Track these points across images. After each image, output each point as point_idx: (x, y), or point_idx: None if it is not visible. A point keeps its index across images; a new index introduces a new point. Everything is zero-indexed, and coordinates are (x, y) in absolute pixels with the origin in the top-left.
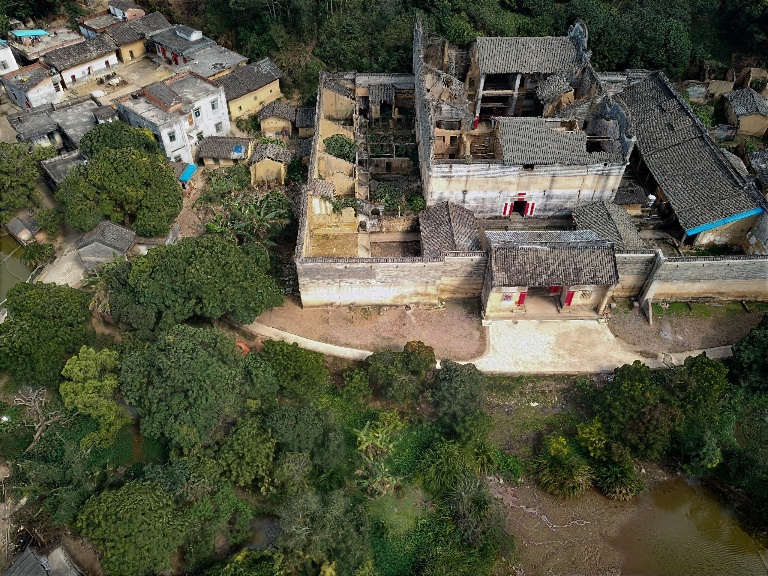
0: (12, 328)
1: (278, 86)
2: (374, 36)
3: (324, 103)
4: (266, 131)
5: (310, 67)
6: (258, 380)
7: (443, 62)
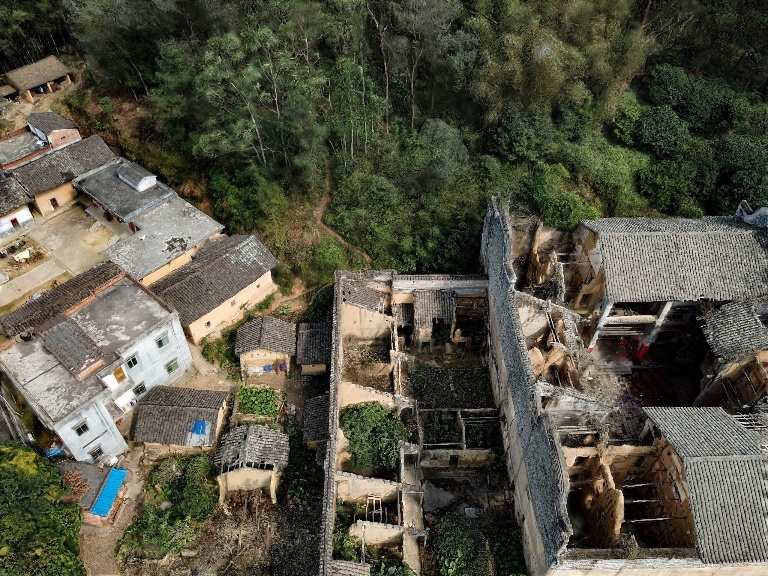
0: None
1: (269, 276)
2: (419, 200)
3: (342, 320)
4: (249, 364)
5: (319, 252)
6: None
7: (531, 251)
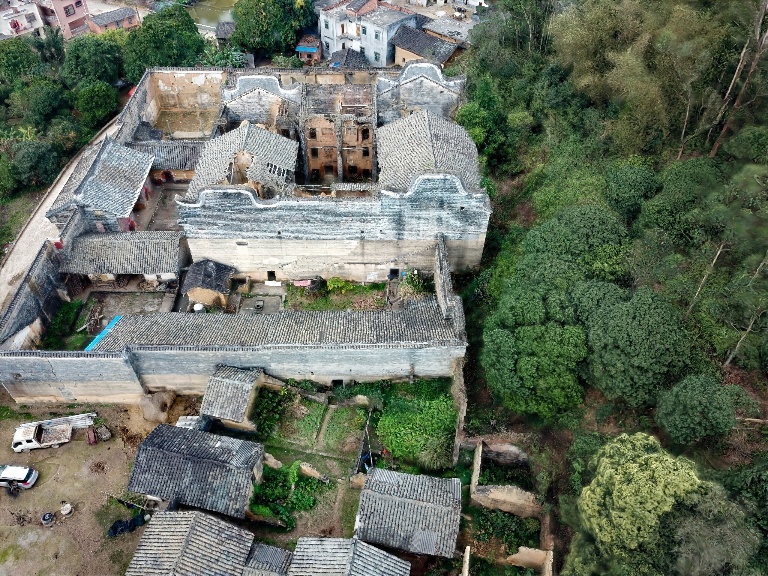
0: None
1: None
2: None
3: None
4: None
5: None
6: (80, 84)
7: None
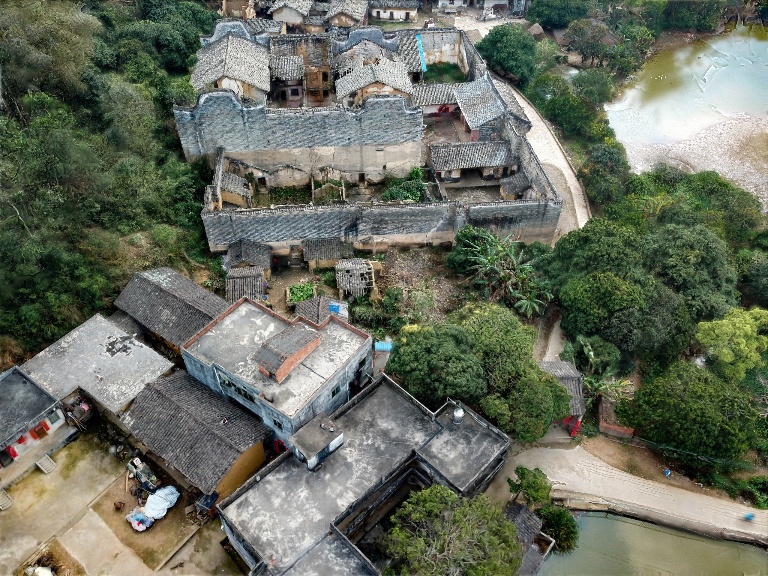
0: None
1: None
2: None
3: None
4: None
5: (165, 236)
6: None
7: None
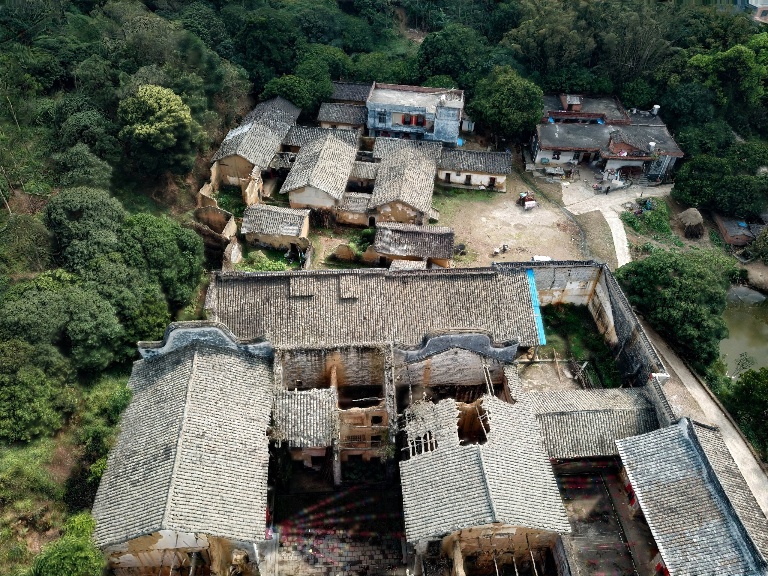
0: None
1: None
2: None
3: None
4: None
5: None
6: None
7: None
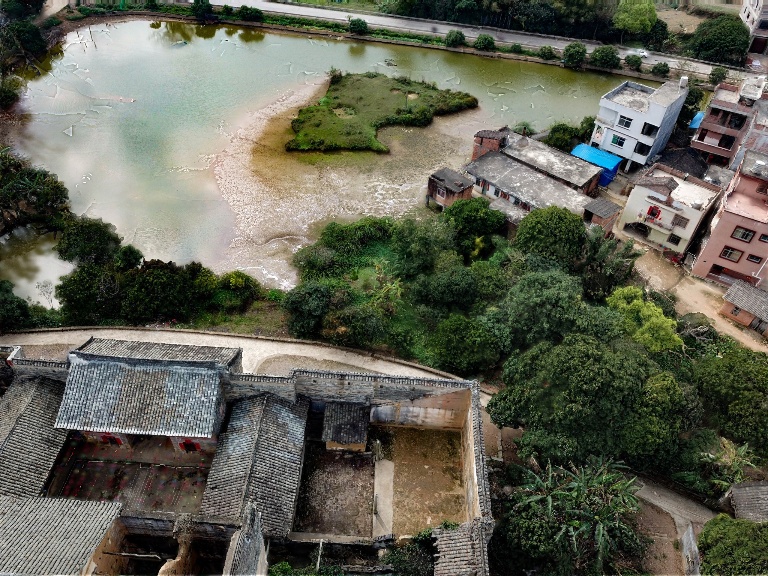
0: (765, 362)
1: None
2: None
3: None
4: None
5: None
6: None
7: None
